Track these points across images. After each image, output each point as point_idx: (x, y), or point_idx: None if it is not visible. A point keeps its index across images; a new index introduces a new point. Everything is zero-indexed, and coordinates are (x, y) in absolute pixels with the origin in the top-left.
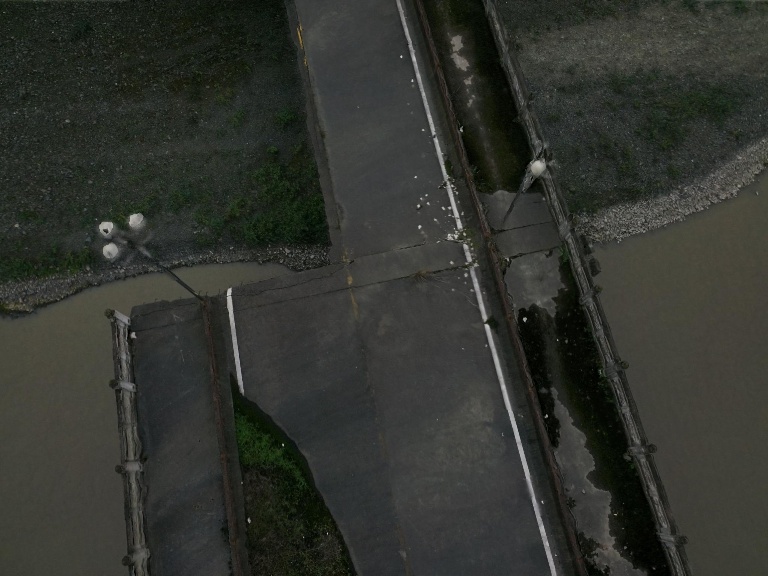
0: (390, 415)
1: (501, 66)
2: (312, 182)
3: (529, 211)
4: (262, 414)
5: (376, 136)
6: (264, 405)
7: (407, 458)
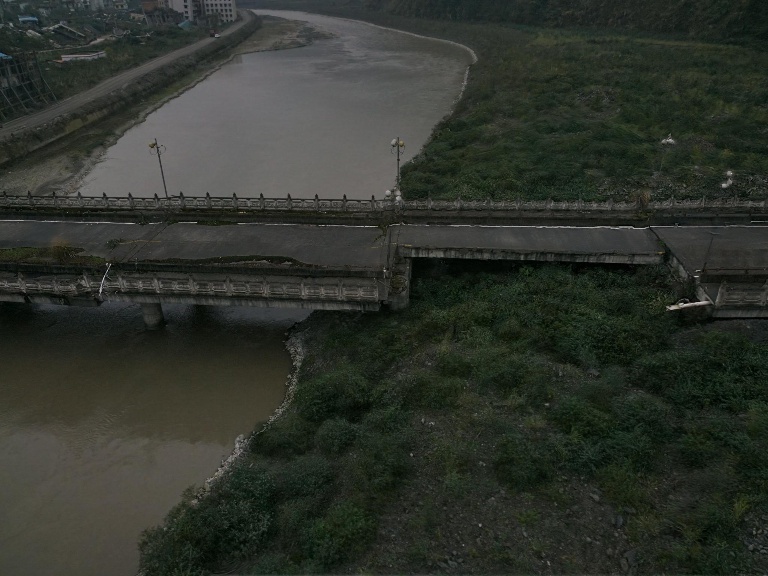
0: None
1: None
2: None
3: None
4: None
5: None
6: None
7: None
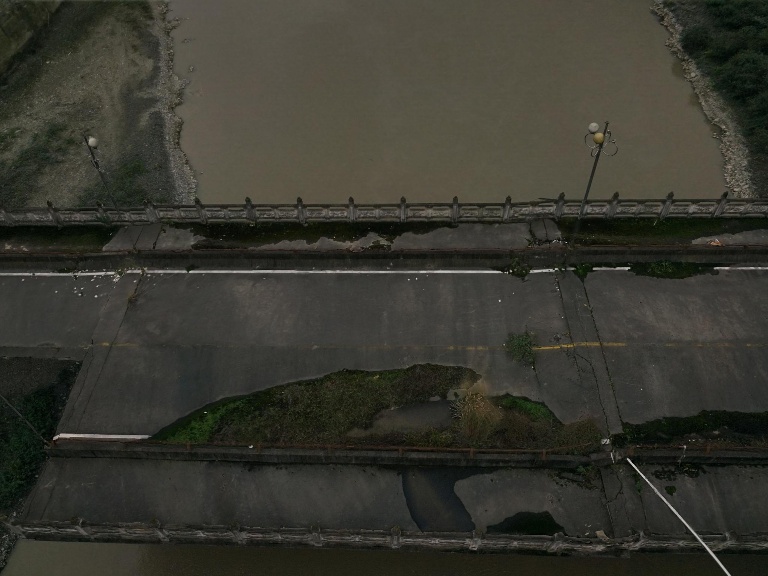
0: (220, 337)
1: (13, 226)
2: (2, 423)
3: (129, 236)
4: (174, 424)
5: (3, 310)
6: (167, 422)
7: (254, 333)
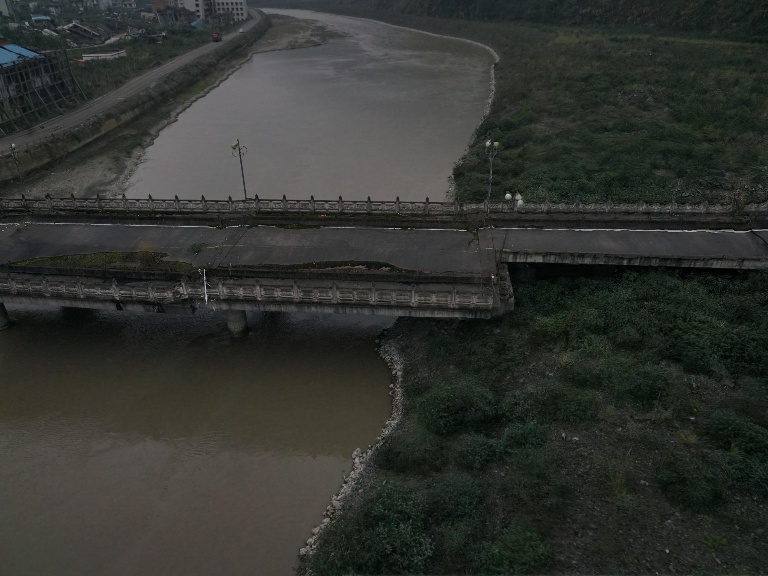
0: (52, 241)
1: None
2: None
3: None
4: None
5: None
6: (7, 262)
7: None
